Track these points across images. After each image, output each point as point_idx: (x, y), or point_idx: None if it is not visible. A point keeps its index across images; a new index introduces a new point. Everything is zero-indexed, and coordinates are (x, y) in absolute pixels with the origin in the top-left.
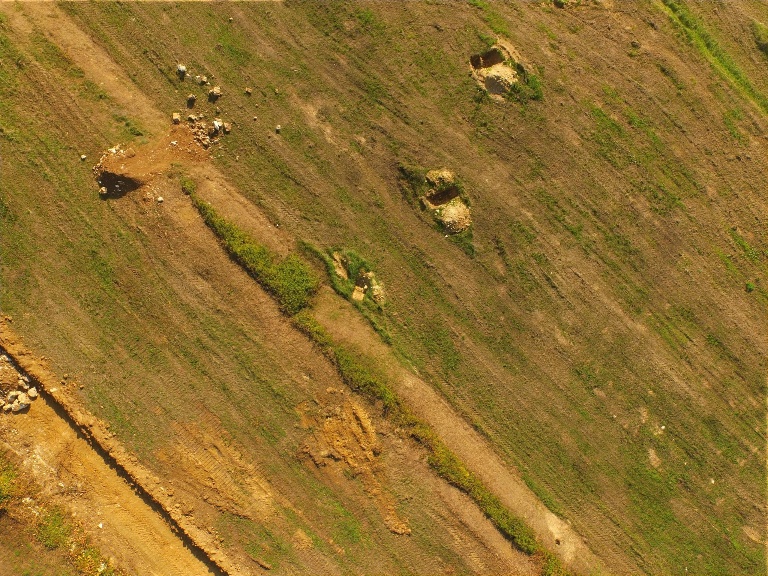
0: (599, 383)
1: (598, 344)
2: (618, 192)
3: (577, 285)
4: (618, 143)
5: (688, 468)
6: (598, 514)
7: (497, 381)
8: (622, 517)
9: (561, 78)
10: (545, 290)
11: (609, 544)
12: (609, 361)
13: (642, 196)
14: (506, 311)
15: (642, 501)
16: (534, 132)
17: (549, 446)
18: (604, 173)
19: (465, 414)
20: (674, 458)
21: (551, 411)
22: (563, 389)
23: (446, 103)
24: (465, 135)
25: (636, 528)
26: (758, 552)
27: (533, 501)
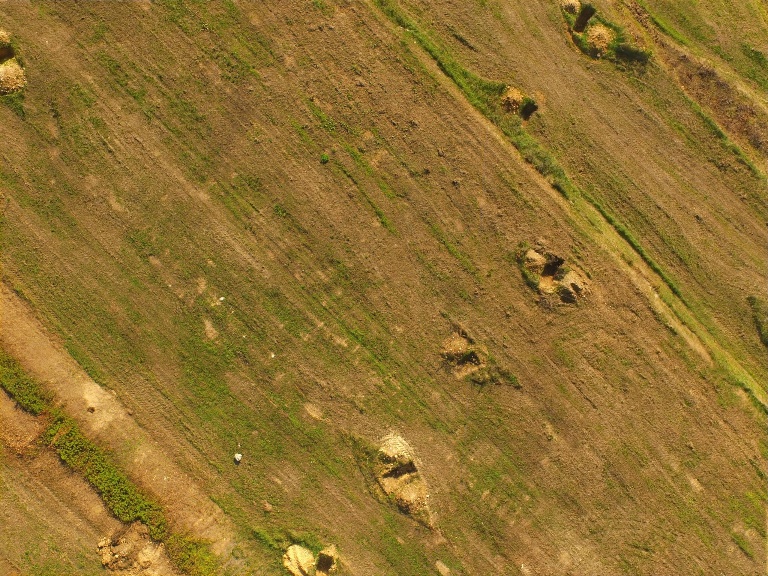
0: (155, 251)
1: (156, 211)
2: (188, 58)
3: (137, 151)
4: (191, 9)
5: (247, 341)
6: (147, 386)
7: (43, 246)
8: (172, 389)
9: None
10: (101, 155)
11: (157, 417)
12: (167, 229)
13: (214, 63)
14: (58, 175)
15: (196, 374)
16: None
17: (96, 314)
18: (174, 39)
19: (6, 278)
20: (232, 330)
21: (100, 278)
22: (114, 256)
23: None
24: None
25: (187, 401)
26: (318, 429)
27: (72, 369)
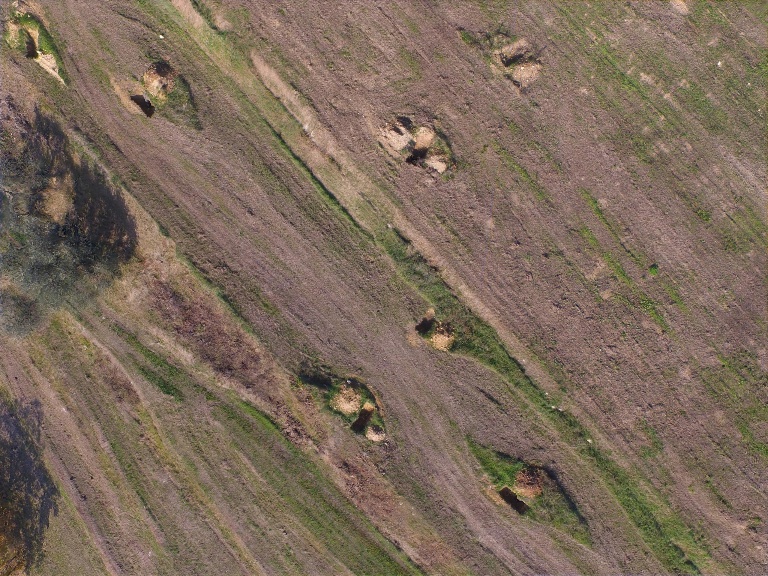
0: None
1: None
2: None
3: None
4: None
5: (747, 79)
6: None
7: None
8: None
9: None
10: None
11: None
12: None
13: (765, 371)
14: None
15: None
16: None
17: None
18: None
19: None
20: (761, 91)
21: None
22: None
23: None
24: None
25: None
26: None
27: None
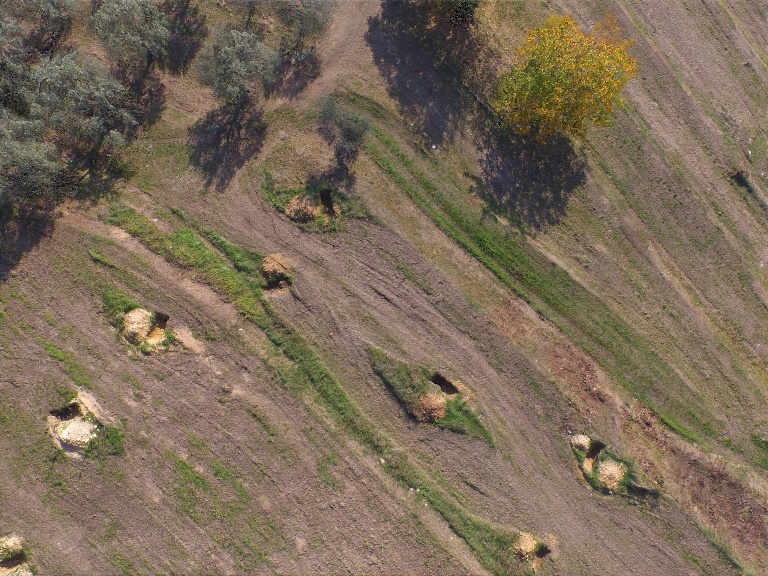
0: None
1: None
2: (200, 550)
3: None
4: (202, 497)
5: None
6: None
7: None
8: None
9: (144, 430)
10: None
11: None
12: None
13: (226, 552)
14: None
15: None
16: (112, 490)
17: None
18: (186, 530)
19: None
20: None
21: None
22: None
23: (19, 463)
24: (38, 496)
25: None
26: None
27: None
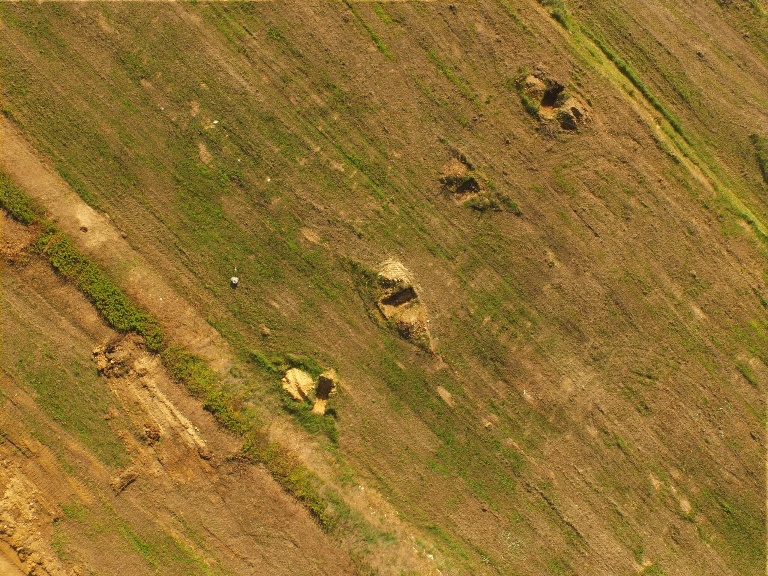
0: (146, 74)
1: (147, 34)
2: None
3: None
4: None
5: (242, 165)
6: (141, 209)
7: (32, 67)
8: (167, 213)
9: None
10: None
11: (152, 241)
12: (159, 52)
13: None
14: None
15: (191, 198)
16: None
17: (87, 136)
18: None
19: None
20: (227, 154)
21: (91, 100)
22: (105, 78)
23: None
24: None
25: (182, 225)
26: (316, 254)
27: (64, 190)
